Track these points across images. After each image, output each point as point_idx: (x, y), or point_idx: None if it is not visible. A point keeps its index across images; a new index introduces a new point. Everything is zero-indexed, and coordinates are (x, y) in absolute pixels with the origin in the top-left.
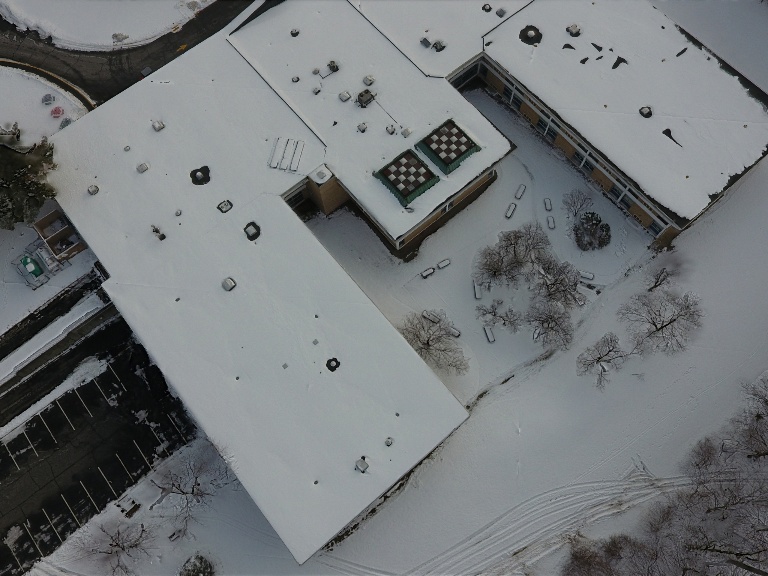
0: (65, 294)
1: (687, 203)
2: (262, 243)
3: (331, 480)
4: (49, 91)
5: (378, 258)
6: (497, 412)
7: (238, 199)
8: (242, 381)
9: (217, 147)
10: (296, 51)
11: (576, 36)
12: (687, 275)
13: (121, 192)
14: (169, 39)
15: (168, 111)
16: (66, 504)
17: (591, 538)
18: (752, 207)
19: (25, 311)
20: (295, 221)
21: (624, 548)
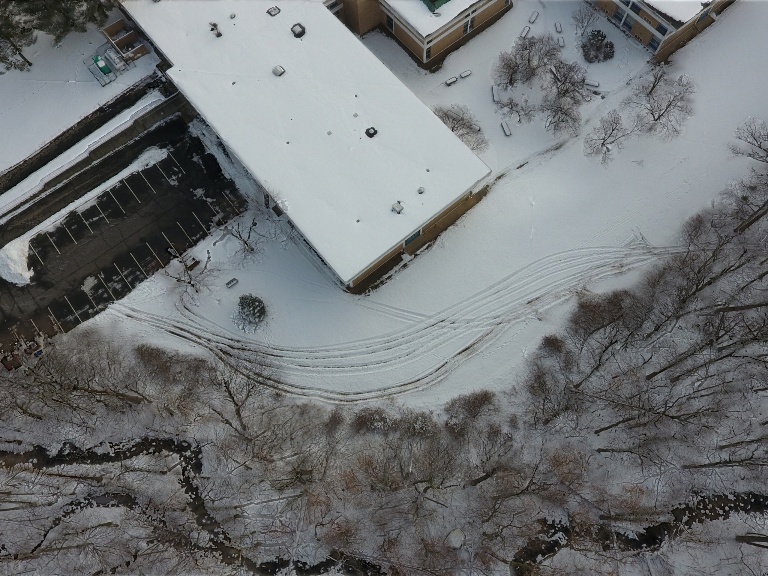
0: (130, 91)
1: (682, 9)
2: (307, 40)
3: (371, 219)
4: None
5: (407, 70)
6: (513, 190)
7: (285, 5)
8: (292, 145)
9: None
10: None
11: None
12: None
13: (181, 0)
14: None
15: None
16: (135, 260)
17: (596, 292)
18: (741, 30)
19: (95, 104)
20: (336, 22)
21: (625, 299)
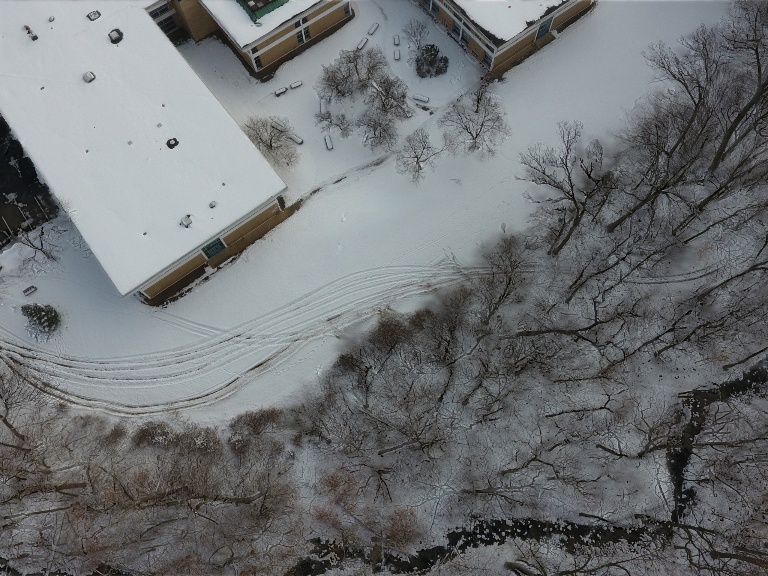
0: None
1: (505, 27)
2: (123, 46)
3: (158, 232)
4: None
5: (238, 78)
6: (327, 205)
7: (106, 10)
8: (91, 153)
9: None
10: None
11: None
12: (513, 102)
13: (3, 1)
14: None
15: None
16: None
17: (399, 311)
18: (580, 49)
19: None
20: (155, 29)
21: (426, 320)
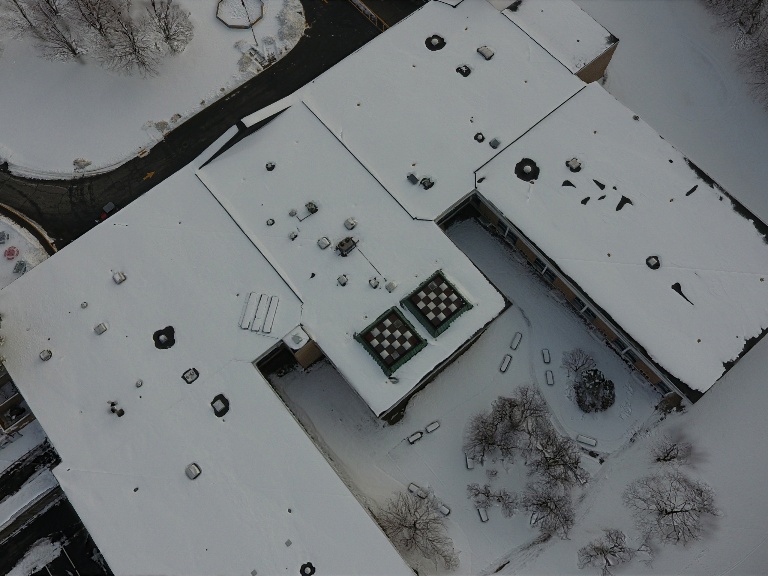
0: (15, 469)
1: (699, 373)
2: (231, 420)
3: None
4: (3, 227)
5: (361, 420)
6: None
7: (205, 367)
8: None
9: (183, 303)
10: (271, 188)
11: (576, 171)
12: (698, 441)
13: (76, 357)
14: (135, 165)
15: (130, 260)
16: None
17: None
18: None
19: None
20: (267, 394)
21: None
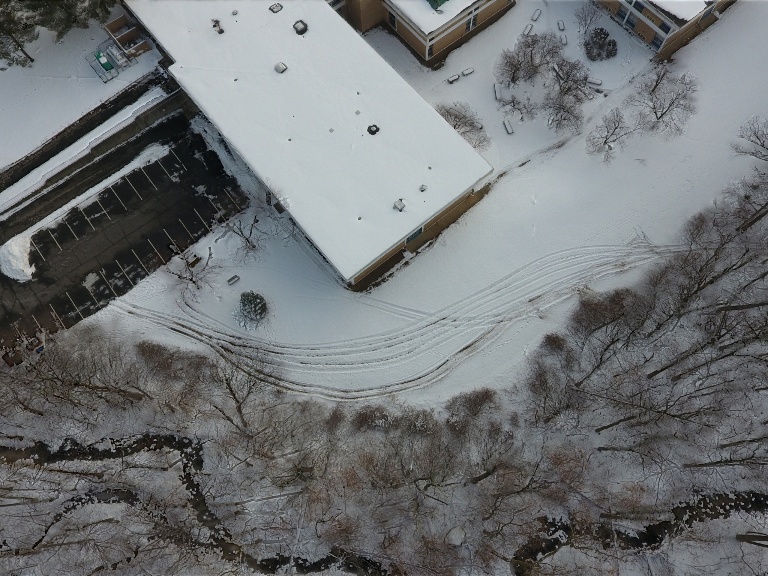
0: (132, 88)
1: (685, 7)
2: (309, 36)
3: (373, 217)
4: None
5: (409, 67)
6: (515, 188)
7: (287, 2)
8: (294, 142)
9: None
10: None
11: None
12: None
13: None
14: None
15: None
16: (136, 257)
17: (597, 291)
18: (744, 29)
19: (97, 101)
20: (338, 19)
21: (626, 298)
